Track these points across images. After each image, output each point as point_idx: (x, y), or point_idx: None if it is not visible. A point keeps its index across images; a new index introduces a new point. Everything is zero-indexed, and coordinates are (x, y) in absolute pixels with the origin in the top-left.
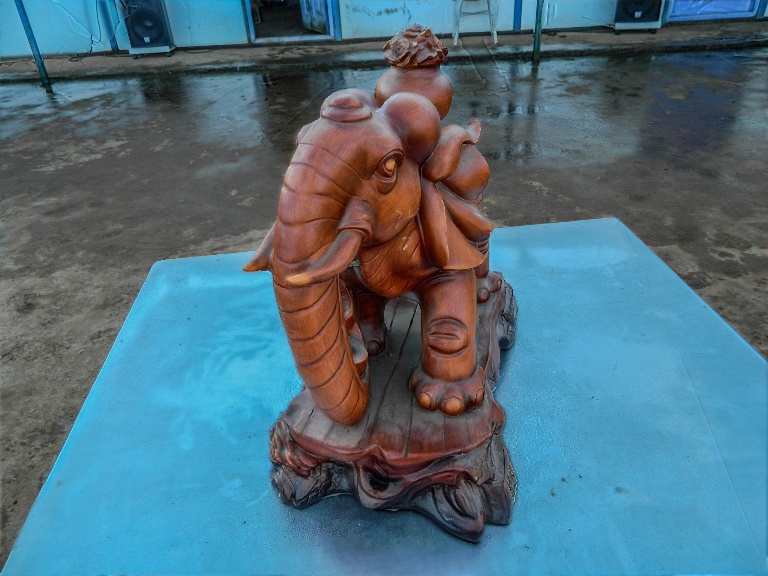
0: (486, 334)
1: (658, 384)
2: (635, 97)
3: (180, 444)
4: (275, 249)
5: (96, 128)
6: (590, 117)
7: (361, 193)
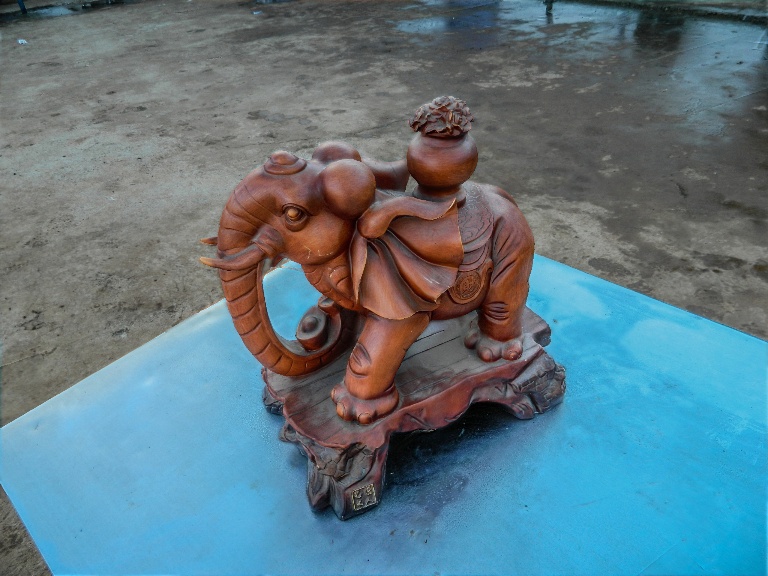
0: (447, 385)
1: (602, 548)
2: None
3: None
4: None
5: (550, 56)
6: None
7: (274, 224)
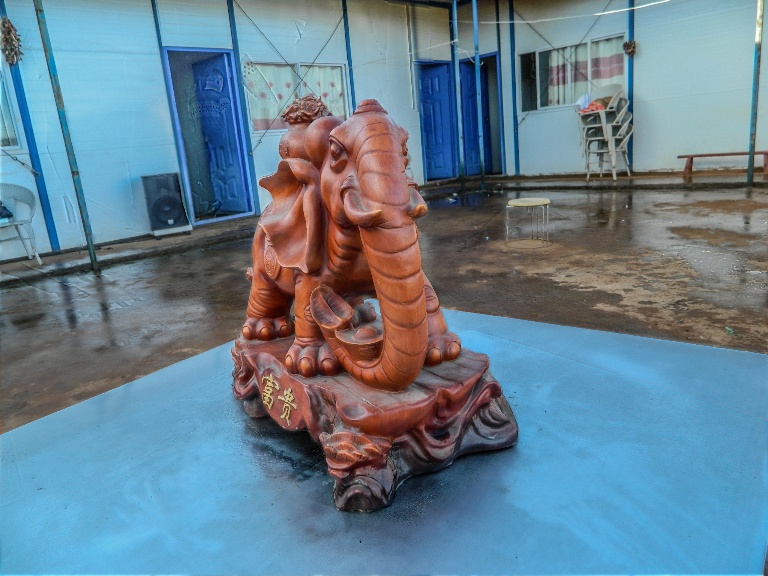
0: None
1: (486, 345)
2: (213, 275)
3: (207, 551)
4: (384, 199)
5: None
6: (189, 295)
7: None
